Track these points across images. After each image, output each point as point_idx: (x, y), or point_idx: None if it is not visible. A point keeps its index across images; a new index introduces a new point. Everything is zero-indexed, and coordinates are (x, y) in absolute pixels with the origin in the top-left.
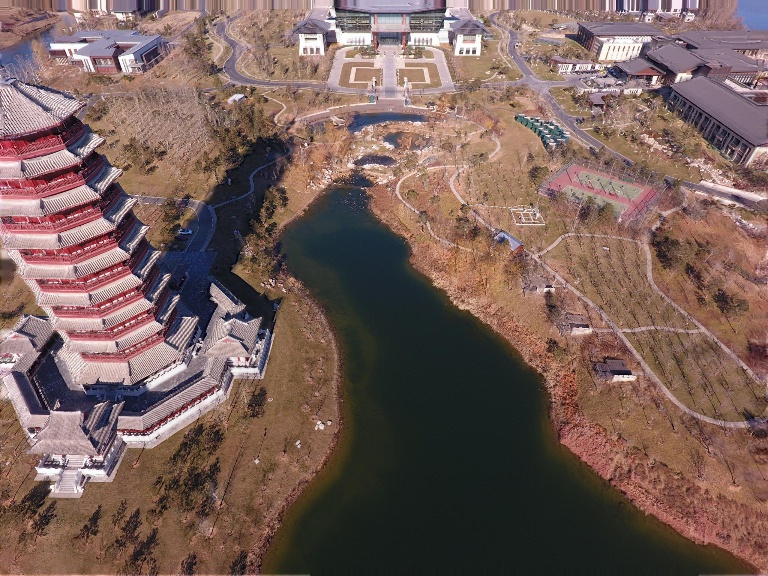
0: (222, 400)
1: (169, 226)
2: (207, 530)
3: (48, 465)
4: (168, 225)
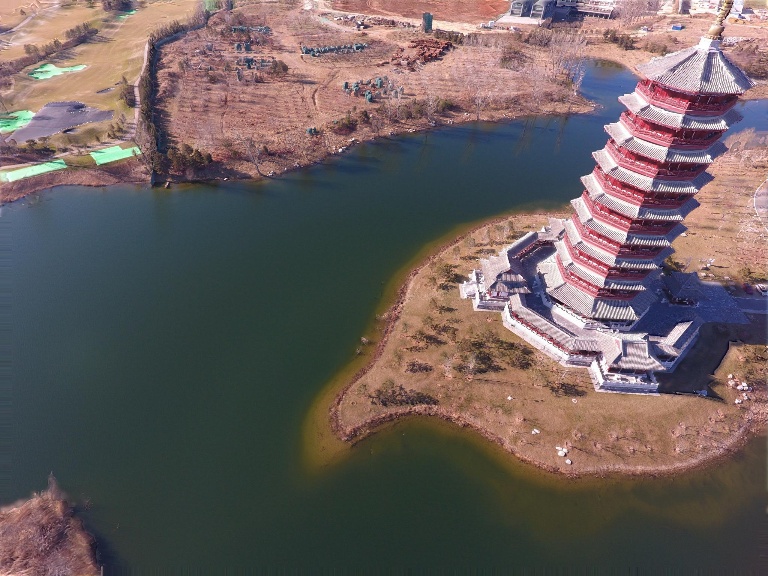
0: (561, 362)
1: (760, 275)
2: (448, 371)
3: (478, 275)
4: (761, 274)
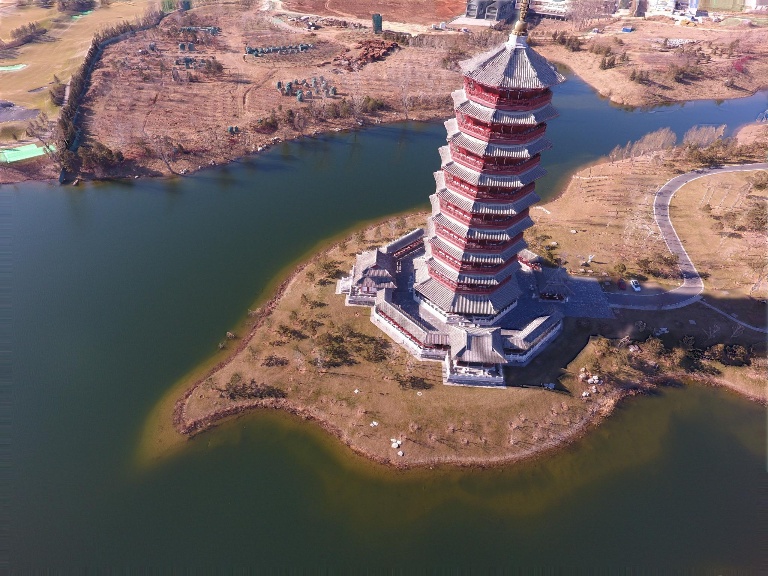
0: (416, 356)
1: (638, 271)
2: None
3: None
4: (639, 270)
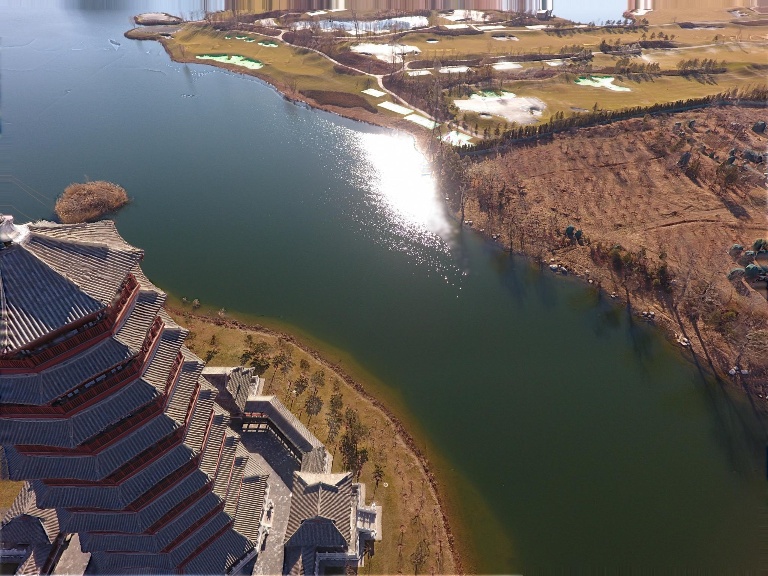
0: None
1: None
2: None
3: (252, 382)
4: None
